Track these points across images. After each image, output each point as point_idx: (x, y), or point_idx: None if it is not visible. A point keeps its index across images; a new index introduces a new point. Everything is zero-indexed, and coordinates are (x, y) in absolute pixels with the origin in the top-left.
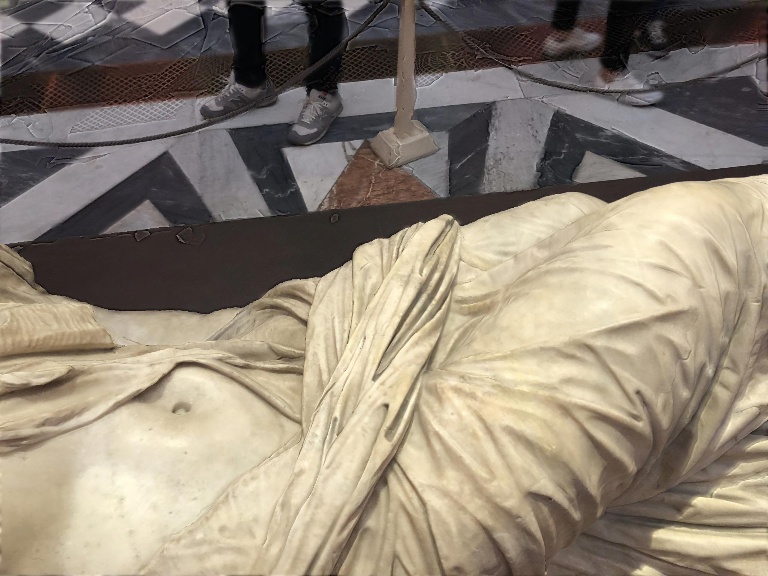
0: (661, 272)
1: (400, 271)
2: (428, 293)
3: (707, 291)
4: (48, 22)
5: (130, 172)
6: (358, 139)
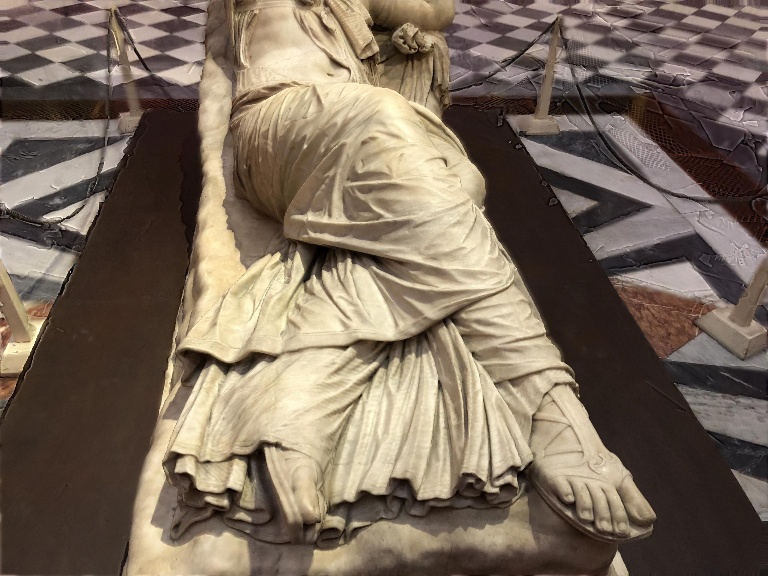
0: None
1: None
2: None
3: (332, 108)
4: None
5: (621, 192)
6: (720, 298)
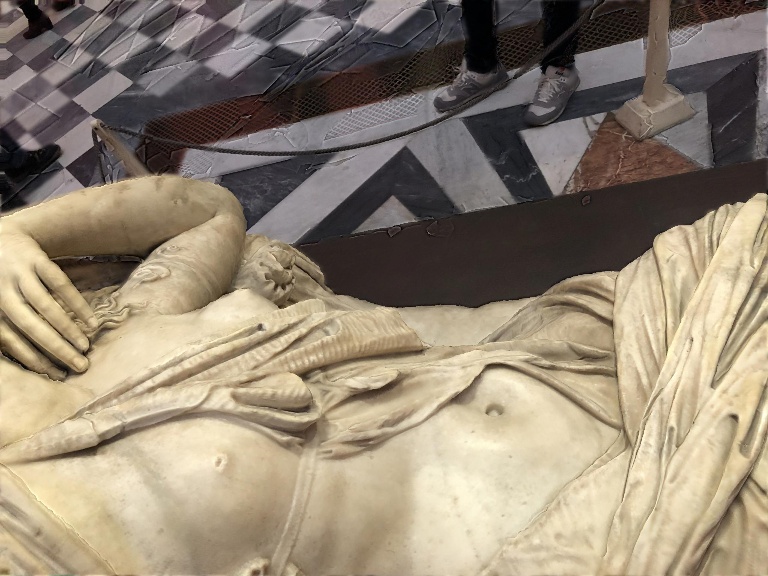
0: None
1: (724, 263)
2: (761, 287)
3: None
4: (301, 40)
5: (374, 170)
6: (600, 112)
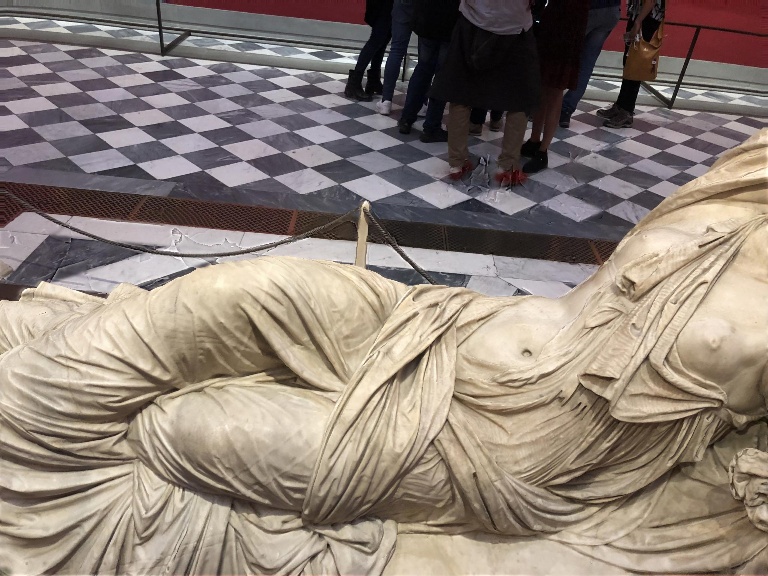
0: (265, 260)
1: (391, 363)
2: None
3: None
4: None
5: None
6: None
